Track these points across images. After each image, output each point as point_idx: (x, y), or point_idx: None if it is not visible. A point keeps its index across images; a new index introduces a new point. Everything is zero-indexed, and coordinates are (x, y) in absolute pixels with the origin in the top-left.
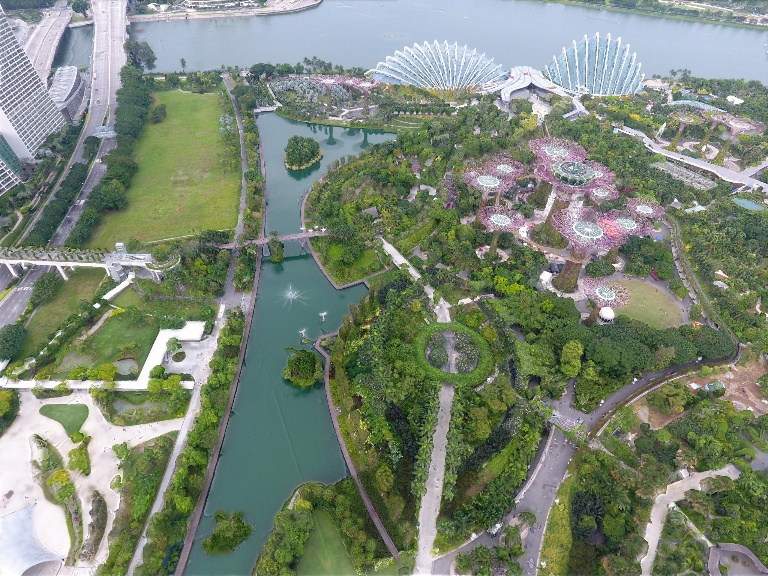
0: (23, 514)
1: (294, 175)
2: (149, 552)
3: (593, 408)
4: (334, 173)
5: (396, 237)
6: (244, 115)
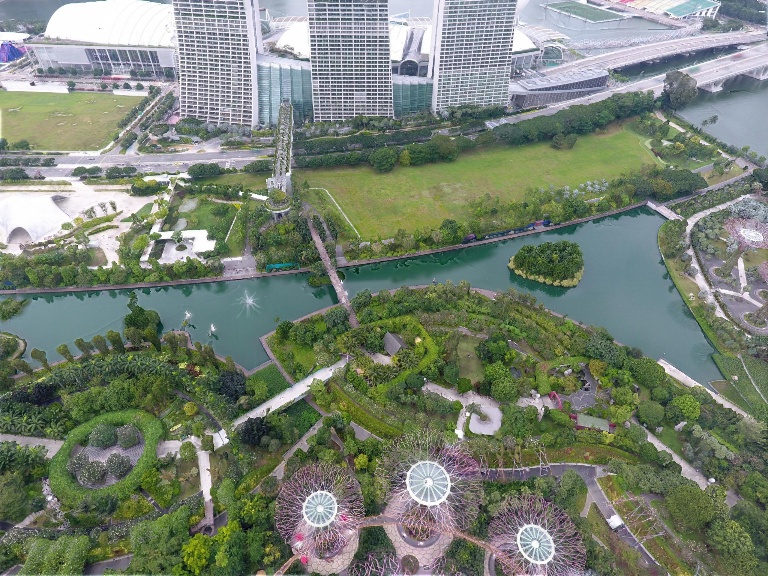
0: (66, 218)
1: None
2: (3, 268)
3: None
4: None
5: (344, 381)
6: (610, 194)
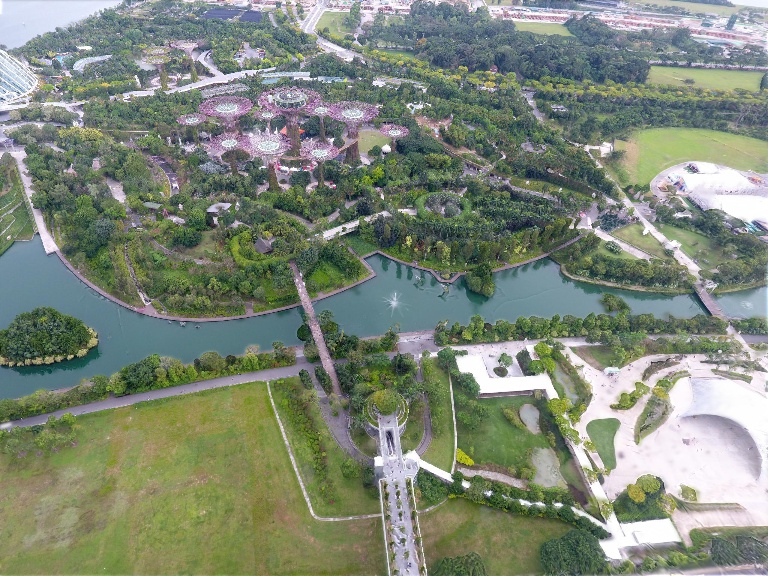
0: (692, 412)
1: (94, 355)
2: None
3: (462, 168)
4: (149, 284)
5: None
6: None
